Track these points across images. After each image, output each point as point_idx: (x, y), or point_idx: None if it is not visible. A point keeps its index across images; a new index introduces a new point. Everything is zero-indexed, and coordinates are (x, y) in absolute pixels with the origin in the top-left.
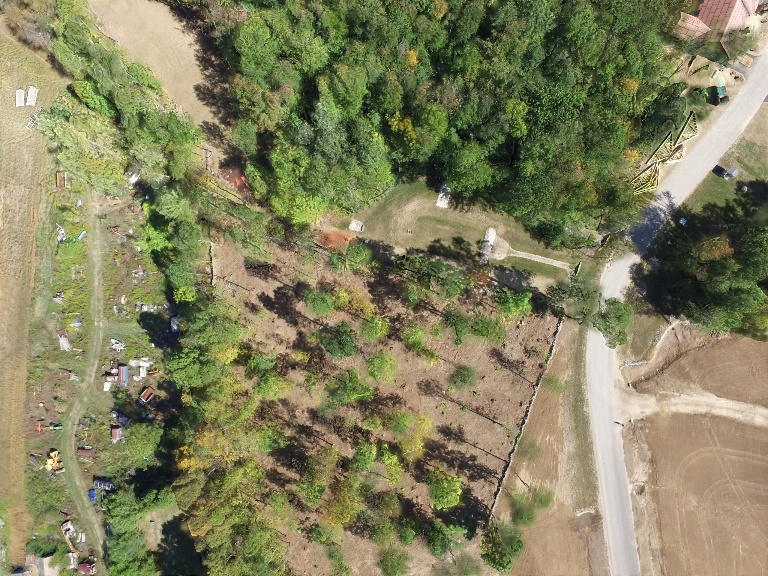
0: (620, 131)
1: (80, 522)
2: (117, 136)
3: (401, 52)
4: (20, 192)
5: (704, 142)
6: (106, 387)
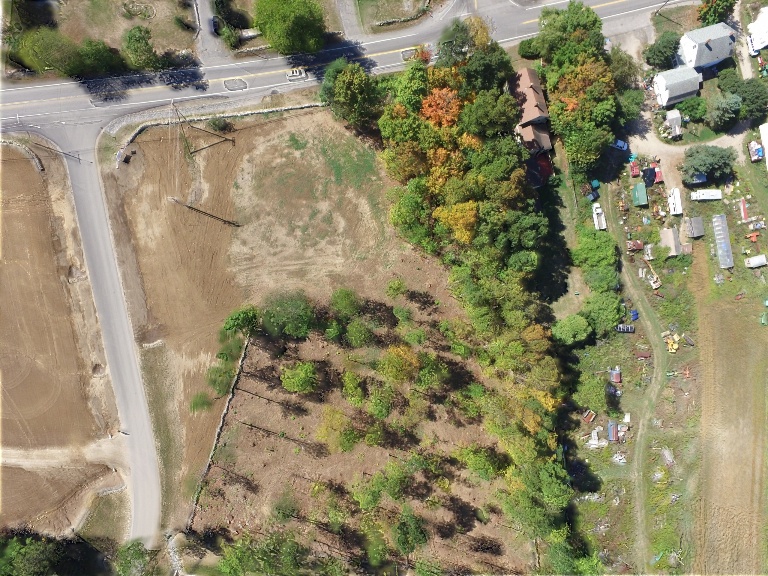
0: None
1: (644, 288)
2: None
3: None
4: None
5: None
6: (628, 417)
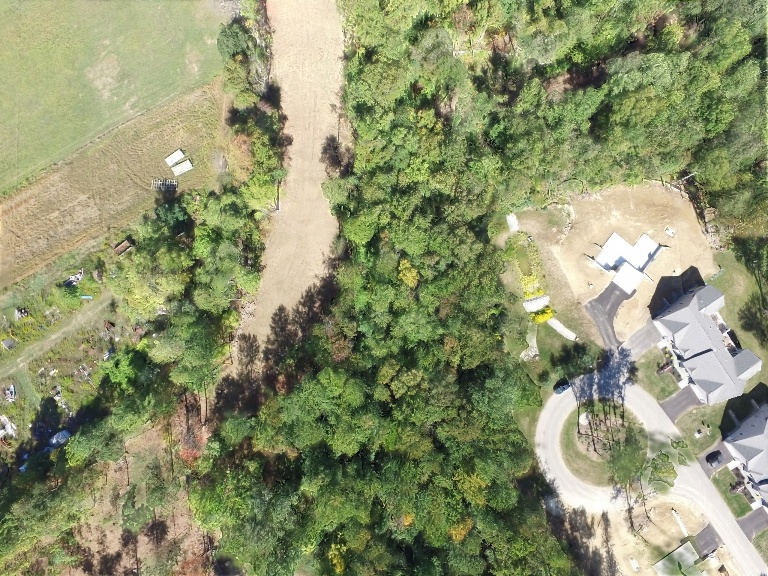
0: None
1: None
2: (185, 283)
3: (401, 516)
4: (93, 213)
5: None
6: None
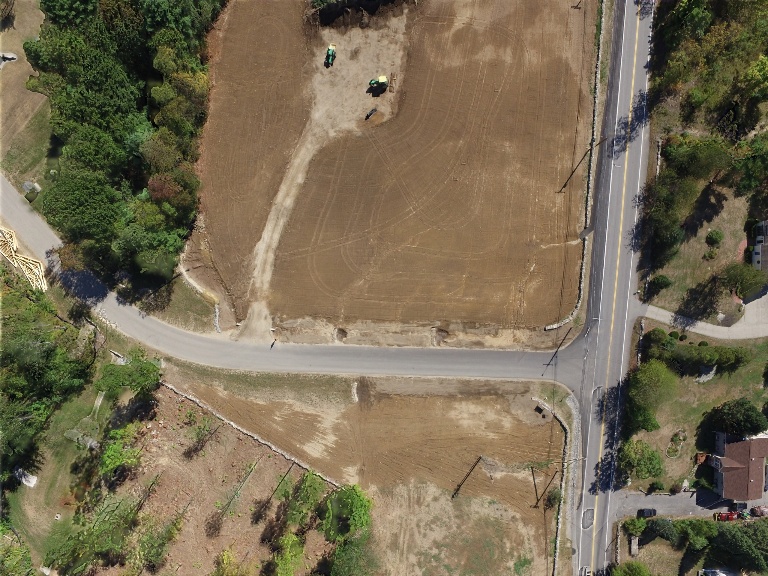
0: None
1: None
2: None
3: None
4: None
5: None
6: None
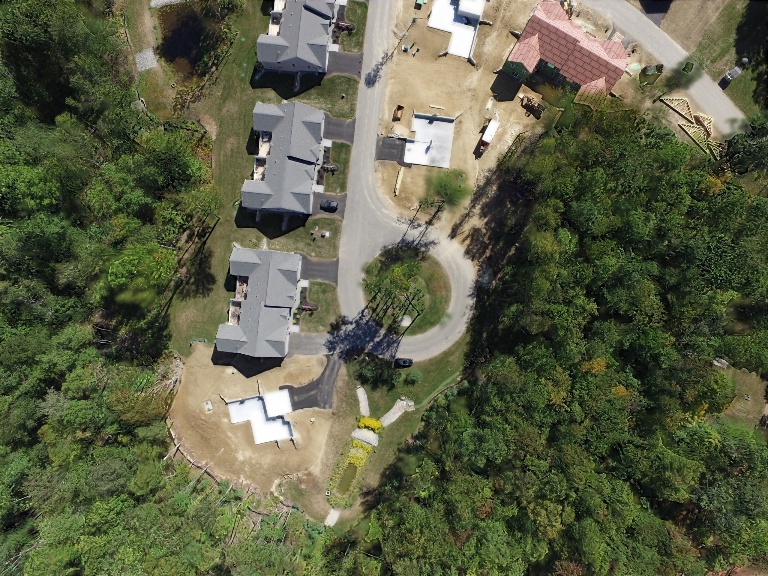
0: (761, 203)
1: None
2: None
3: None
4: None
5: (695, 94)
6: None
